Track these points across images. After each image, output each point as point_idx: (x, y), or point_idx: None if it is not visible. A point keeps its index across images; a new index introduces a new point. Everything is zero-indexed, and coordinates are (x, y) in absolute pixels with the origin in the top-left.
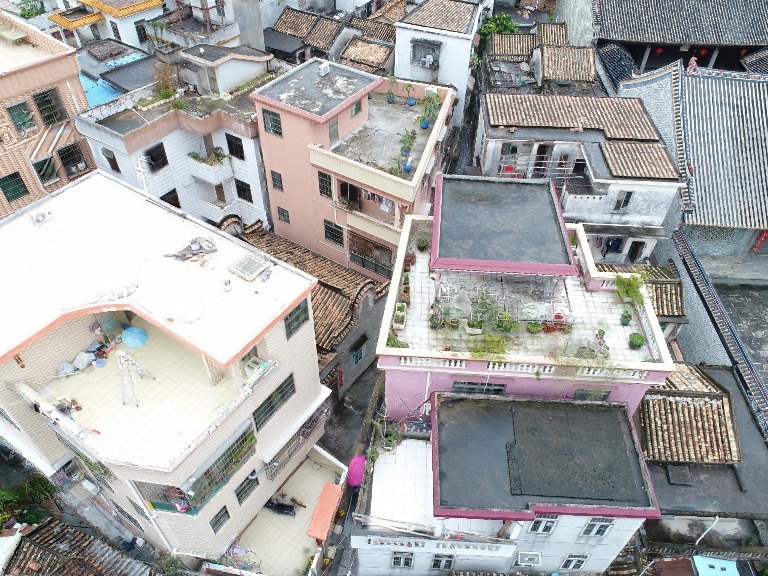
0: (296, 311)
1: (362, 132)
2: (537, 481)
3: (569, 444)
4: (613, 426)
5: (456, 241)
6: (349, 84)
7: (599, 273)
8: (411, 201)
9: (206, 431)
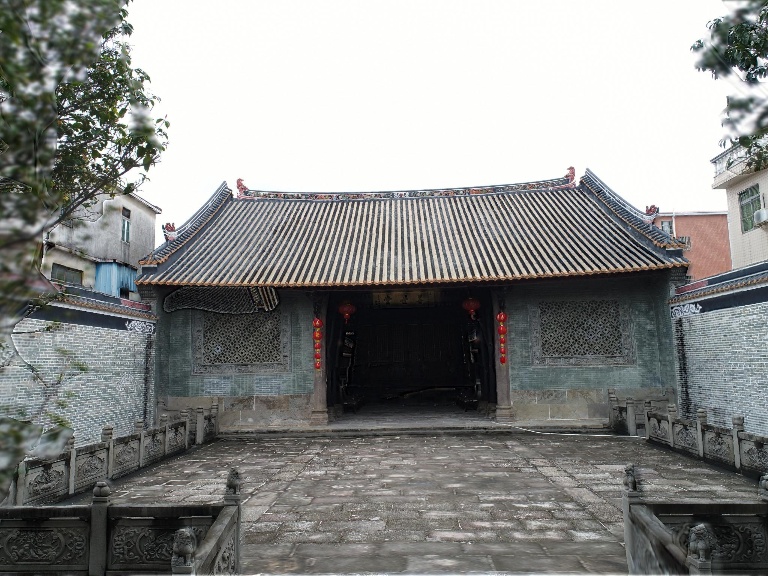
0: None
1: None
2: None
3: None
4: None
5: None
6: None
7: None
8: None
9: None
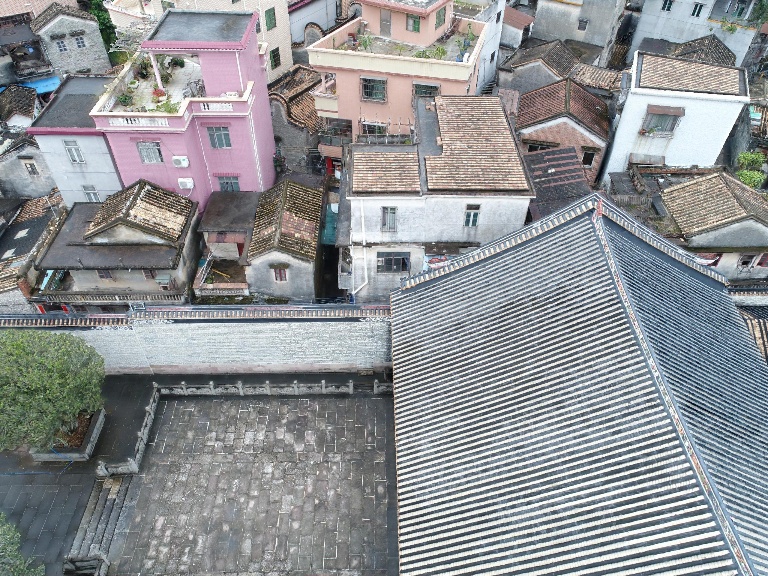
0: (168, 4)
1: (406, 45)
2: (69, 100)
3: (85, 110)
4: (88, 124)
5: (186, 17)
6: (415, 2)
7: (188, 100)
8: (310, 63)
9: (118, 7)
